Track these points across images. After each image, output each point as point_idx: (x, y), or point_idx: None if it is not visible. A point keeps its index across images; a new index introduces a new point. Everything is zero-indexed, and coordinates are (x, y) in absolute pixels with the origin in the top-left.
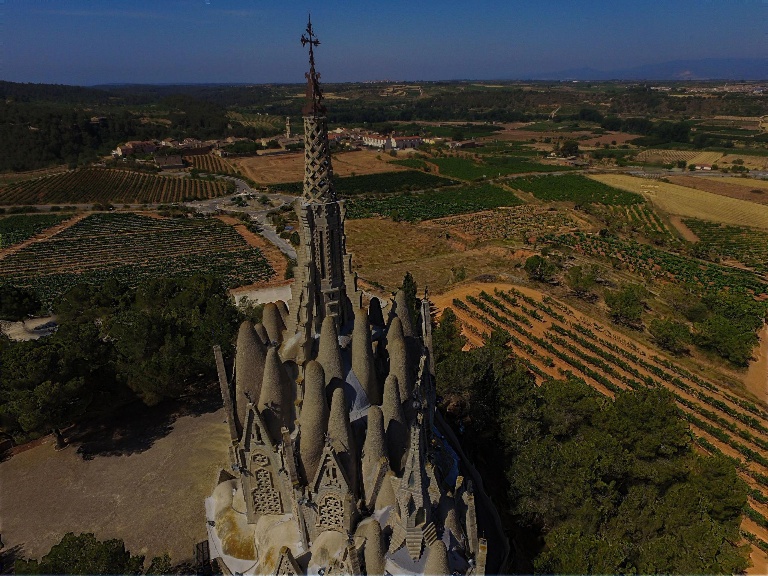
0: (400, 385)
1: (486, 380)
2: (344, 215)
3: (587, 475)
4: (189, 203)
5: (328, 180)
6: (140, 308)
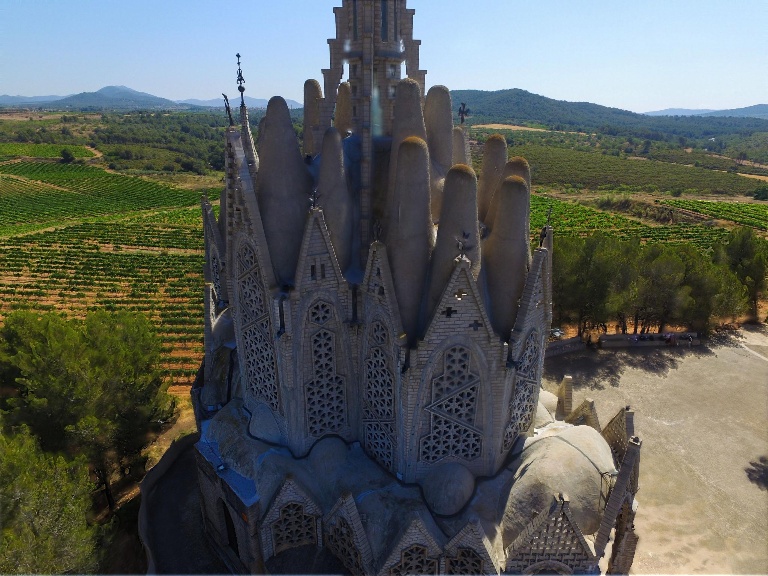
0: None
1: None
2: None
3: None
4: None
5: None
6: None
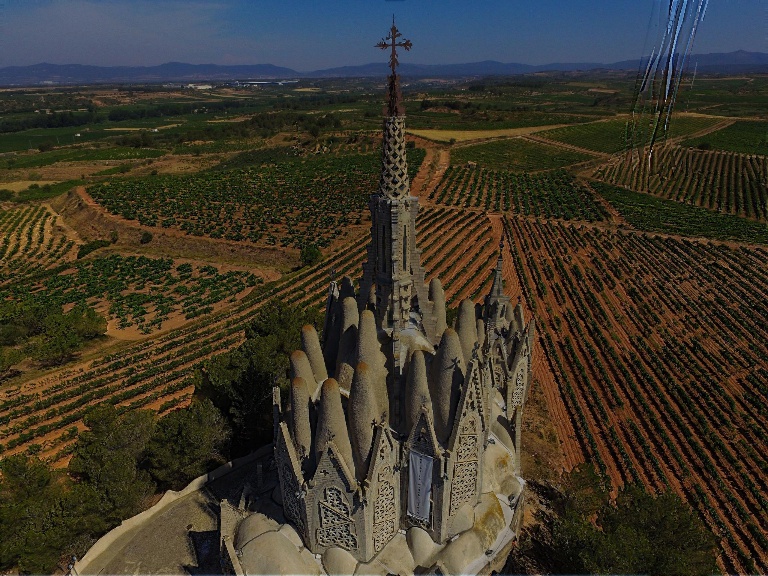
0: None
1: (260, 375)
2: None
3: None
4: None
5: None
6: None
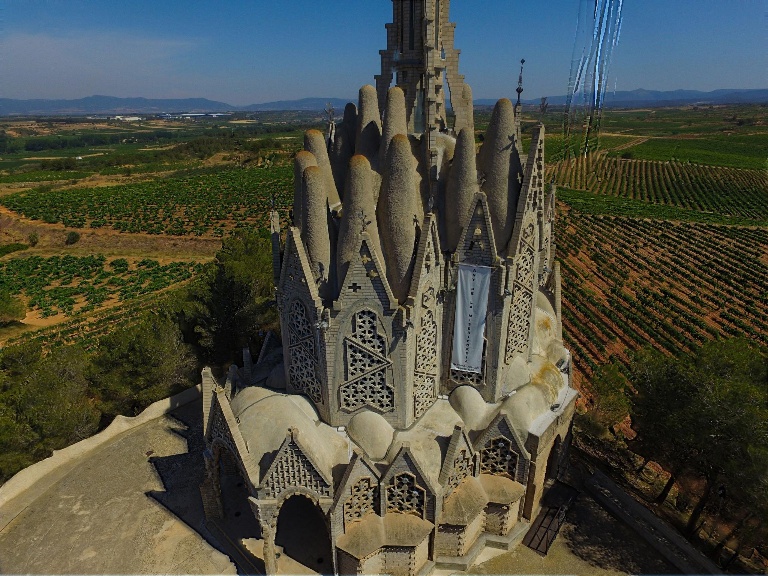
0: None
1: (232, 281)
2: None
3: None
4: None
5: None
6: None
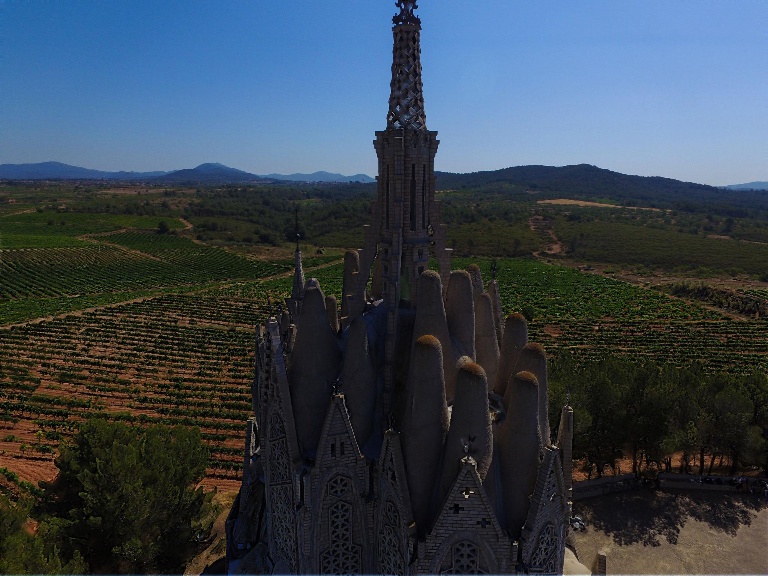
0: None
1: None
2: None
3: None
4: None
5: None
6: None
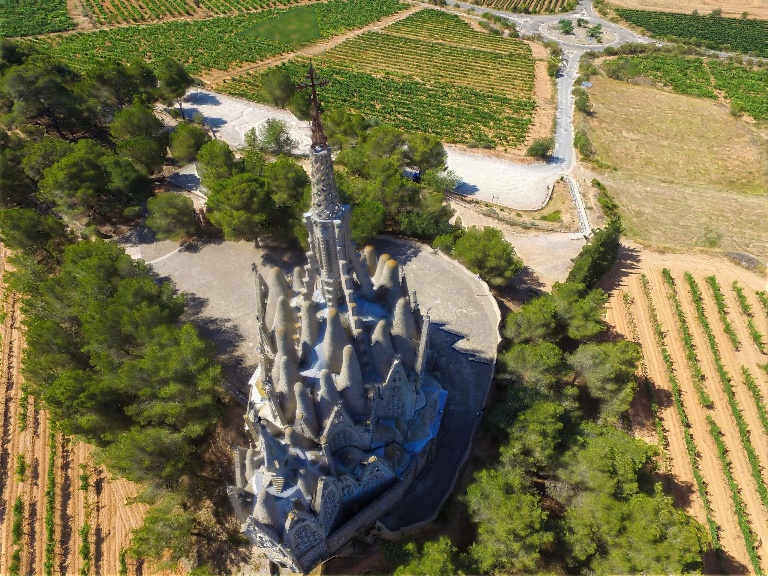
0: (344, 376)
1: (520, 393)
2: (337, 233)
3: (504, 532)
4: (516, 15)
5: (326, 202)
6: (367, 150)
